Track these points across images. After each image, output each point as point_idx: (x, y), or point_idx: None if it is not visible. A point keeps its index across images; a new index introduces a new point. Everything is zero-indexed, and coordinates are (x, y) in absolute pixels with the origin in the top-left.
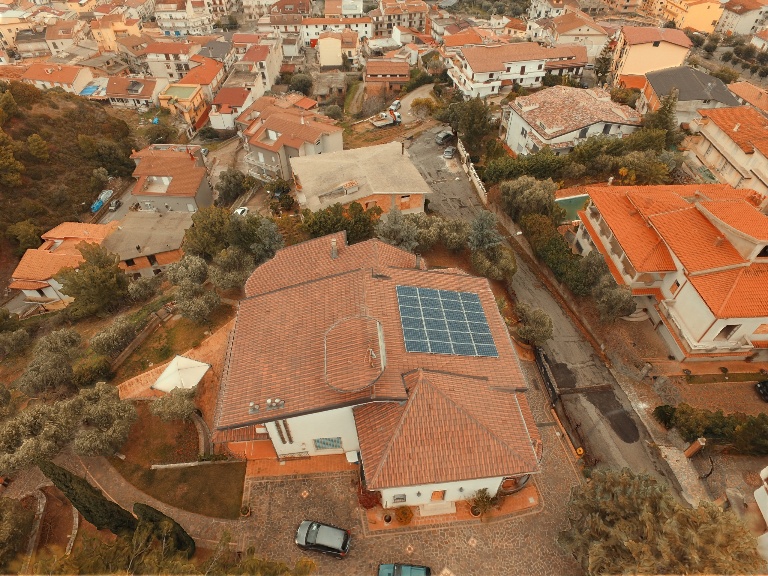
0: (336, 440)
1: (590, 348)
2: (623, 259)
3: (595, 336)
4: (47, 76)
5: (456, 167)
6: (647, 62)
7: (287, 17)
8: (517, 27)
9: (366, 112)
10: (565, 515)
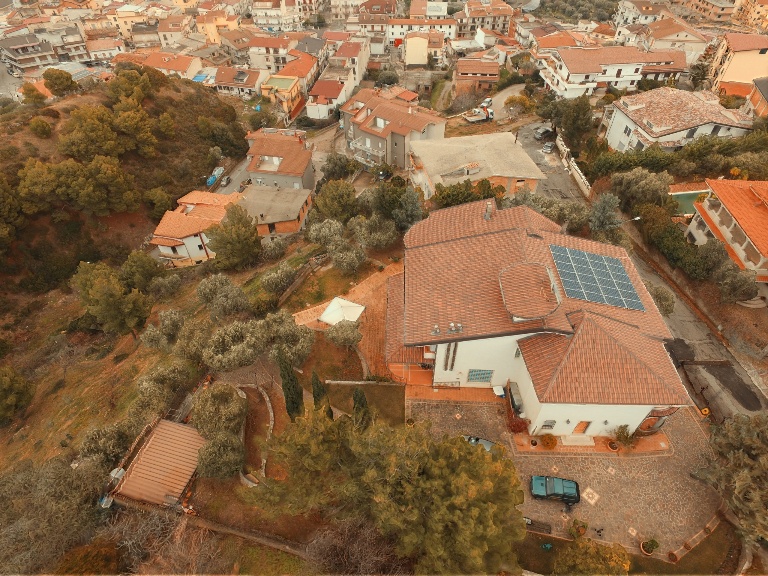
0: (488, 373)
1: (706, 328)
2: (745, 247)
3: (711, 318)
4: (164, 64)
5: (555, 161)
6: (751, 69)
7: (375, 17)
8: (605, 32)
9: (458, 108)
10: (695, 461)
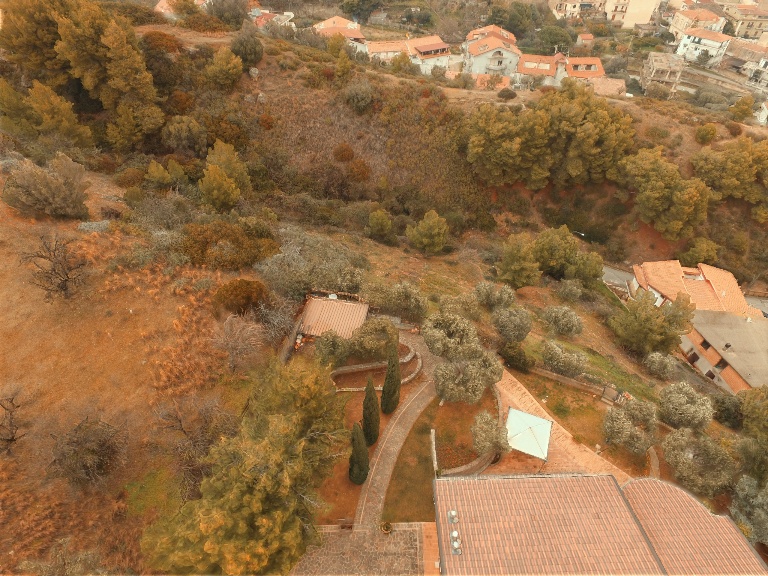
0: None
1: None
2: None
3: None
4: None
5: None
6: None
7: None
8: None
9: None
10: None
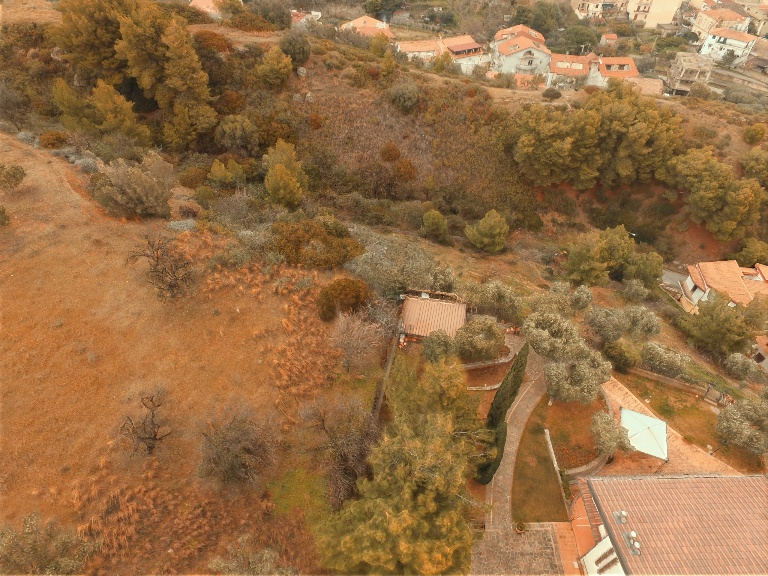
0: None
1: None
2: None
3: None
4: None
5: None
6: None
7: None
8: None
9: None
10: None
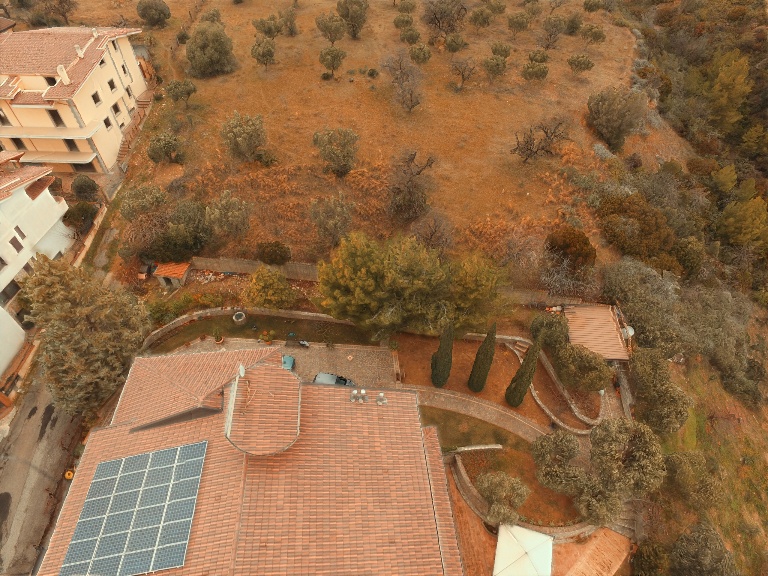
0: None
1: None
2: None
3: None
4: None
5: None
6: None
7: None
8: None
9: None
10: None
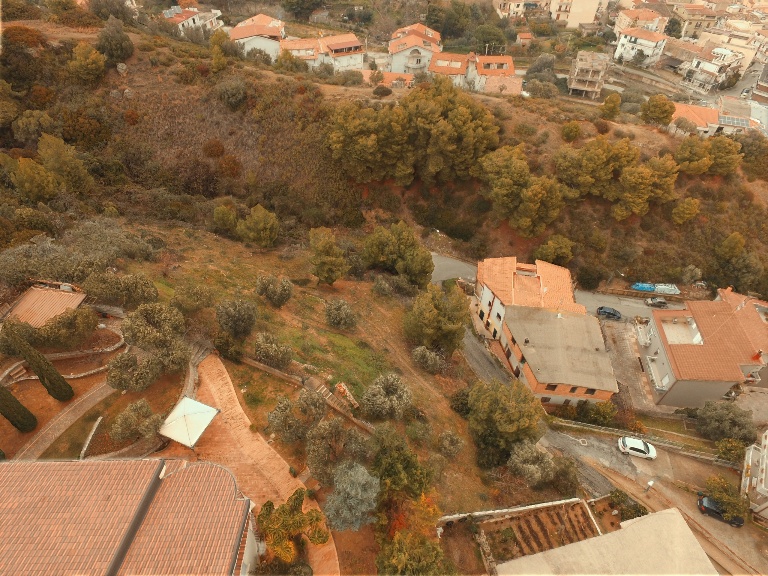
0: None
1: None
2: None
3: None
4: None
5: None
6: None
7: None
8: None
9: None
10: None
